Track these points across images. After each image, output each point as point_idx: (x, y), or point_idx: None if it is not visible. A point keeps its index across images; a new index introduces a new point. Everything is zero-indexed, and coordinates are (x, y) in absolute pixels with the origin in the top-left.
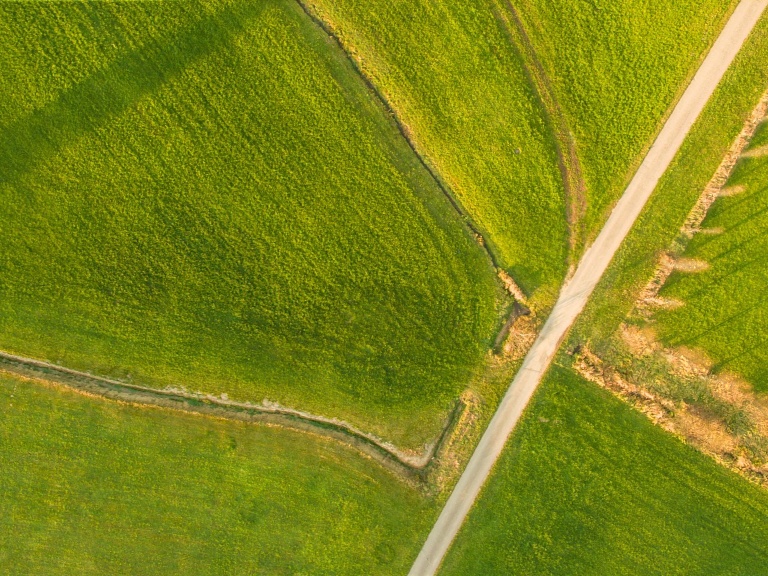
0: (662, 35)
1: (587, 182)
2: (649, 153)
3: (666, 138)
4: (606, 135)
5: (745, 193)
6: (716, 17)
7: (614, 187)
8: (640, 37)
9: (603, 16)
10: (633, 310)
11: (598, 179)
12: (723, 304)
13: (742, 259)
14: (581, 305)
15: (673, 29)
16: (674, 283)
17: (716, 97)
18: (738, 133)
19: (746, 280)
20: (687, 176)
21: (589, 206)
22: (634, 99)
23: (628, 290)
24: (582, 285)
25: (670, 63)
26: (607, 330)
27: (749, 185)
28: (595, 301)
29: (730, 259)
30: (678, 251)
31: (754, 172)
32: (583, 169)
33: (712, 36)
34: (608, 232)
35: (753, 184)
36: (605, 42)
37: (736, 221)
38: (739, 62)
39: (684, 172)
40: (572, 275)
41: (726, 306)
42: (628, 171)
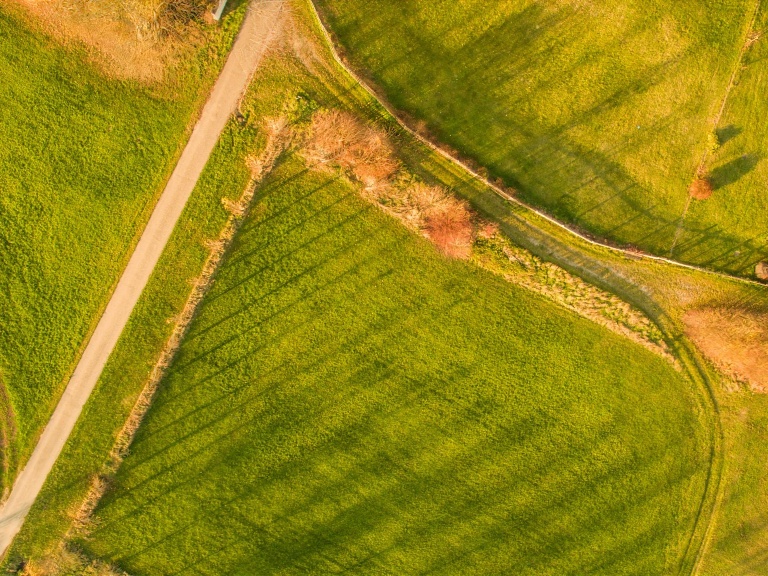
0: (73, 269)
1: (15, 408)
2: (70, 382)
3: (85, 367)
4: (29, 364)
5: (170, 418)
6: (120, 254)
7: (40, 414)
8: (53, 271)
9: (15, 250)
10: (71, 529)
11: (25, 406)
12: (160, 523)
13: (173, 481)
14: (19, 525)
15: (83, 264)
16: (109, 503)
17: (129, 329)
18: (156, 362)
19: (179, 500)
20: (111, 403)
21: (19, 431)
22: (53, 330)
23: (64, 510)
24: (18, 506)
25: (83, 296)
26: (47, 548)
27: (174, 411)
28: (32, 521)
29: (162, 481)
30: (110, 473)
31: (177, 398)
32: (10, 396)
33: (118, 272)
34: (39, 456)
35: (178, 410)
36: (20, 275)
37: (164, 445)
38: (147, 296)
39: (108, 399)
40: (7, 497)
41: (163, 525)
42: (52, 398)
